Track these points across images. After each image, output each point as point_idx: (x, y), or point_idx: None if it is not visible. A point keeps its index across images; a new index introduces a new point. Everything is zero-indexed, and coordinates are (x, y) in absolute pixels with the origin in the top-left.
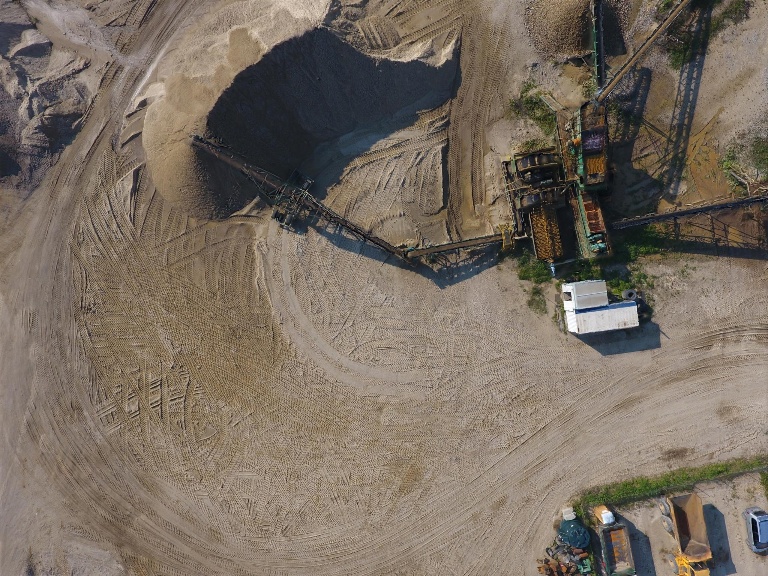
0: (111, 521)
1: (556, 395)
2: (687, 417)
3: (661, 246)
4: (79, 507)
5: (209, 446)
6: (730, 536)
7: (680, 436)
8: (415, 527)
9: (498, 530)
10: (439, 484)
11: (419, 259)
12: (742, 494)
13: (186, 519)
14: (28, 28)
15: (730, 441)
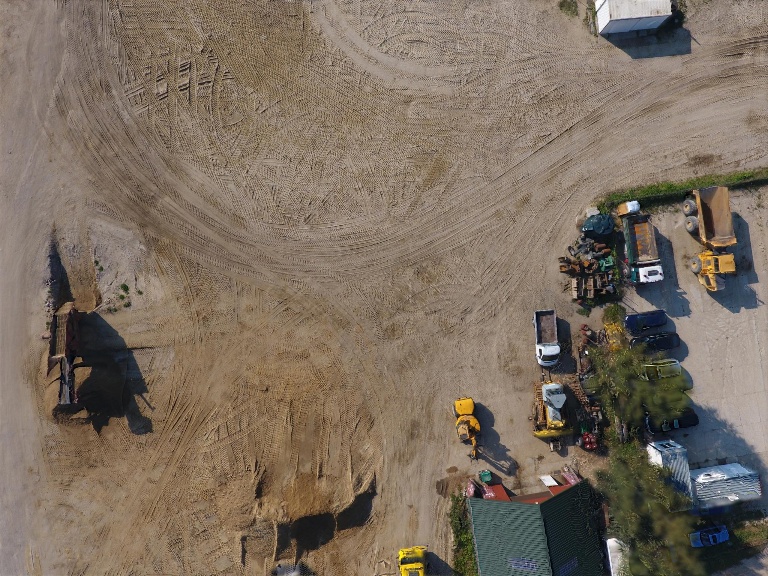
0: (135, 201)
1: (584, 96)
2: (715, 123)
3: None
4: (104, 185)
5: (235, 132)
6: (753, 245)
7: (707, 142)
8: (438, 221)
9: (521, 228)
10: (463, 180)
11: None
12: (767, 204)
13: (210, 203)
14: None
15: (757, 150)
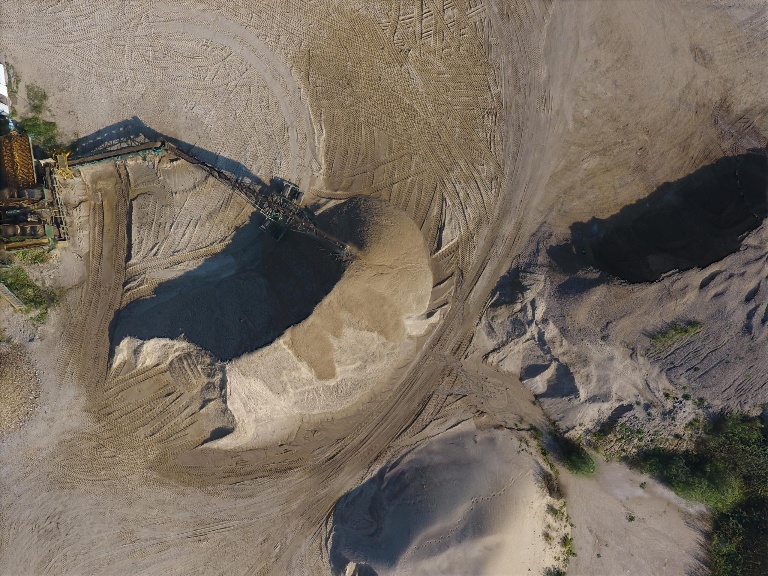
0: None
1: None
2: None
3: None
4: None
5: None
6: None
7: None
8: None
9: None
10: None
11: None
12: None
13: None
14: (541, 395)
15: None
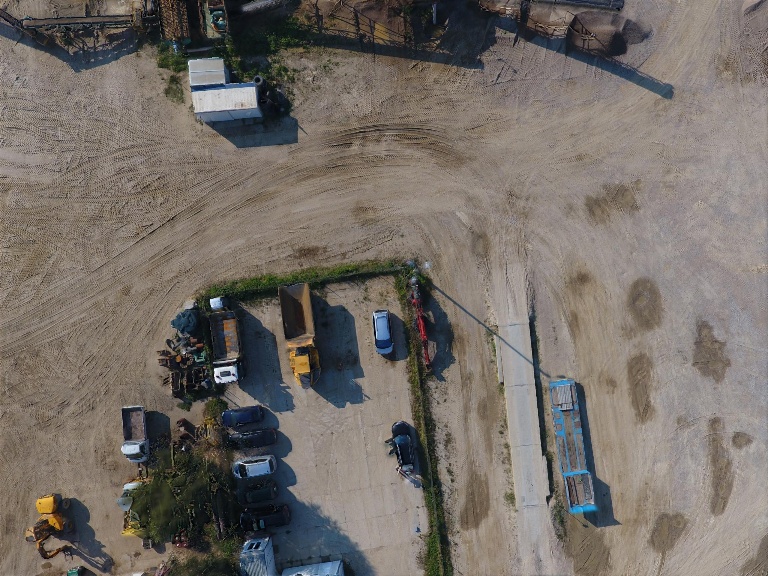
0: None
1: (187, 186)
2: (320, 215)
3: (303, 38)
4: None
5: None
6: (360, 339)
7: (312, 234)
8: (36, 312)
9: (120, 320)
10: (62, 270)
11: (54, 40)
12: (374, 297)
13: None
14: None
15: (364, 242)
